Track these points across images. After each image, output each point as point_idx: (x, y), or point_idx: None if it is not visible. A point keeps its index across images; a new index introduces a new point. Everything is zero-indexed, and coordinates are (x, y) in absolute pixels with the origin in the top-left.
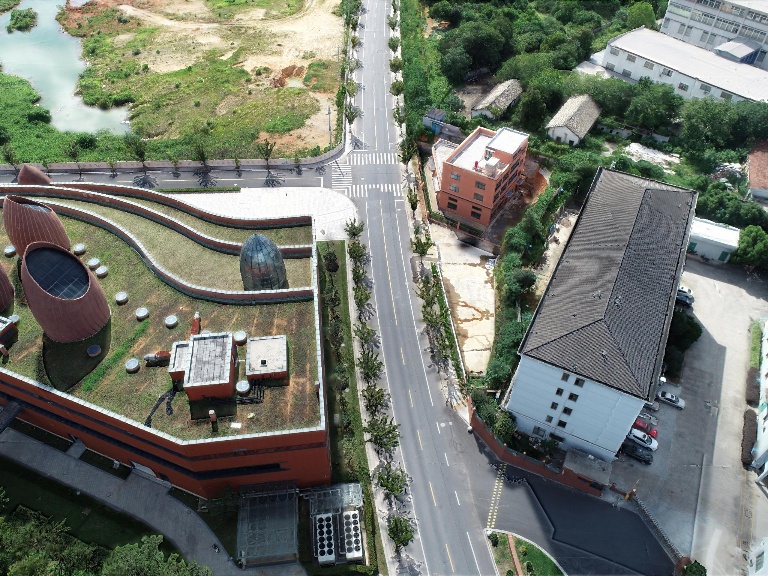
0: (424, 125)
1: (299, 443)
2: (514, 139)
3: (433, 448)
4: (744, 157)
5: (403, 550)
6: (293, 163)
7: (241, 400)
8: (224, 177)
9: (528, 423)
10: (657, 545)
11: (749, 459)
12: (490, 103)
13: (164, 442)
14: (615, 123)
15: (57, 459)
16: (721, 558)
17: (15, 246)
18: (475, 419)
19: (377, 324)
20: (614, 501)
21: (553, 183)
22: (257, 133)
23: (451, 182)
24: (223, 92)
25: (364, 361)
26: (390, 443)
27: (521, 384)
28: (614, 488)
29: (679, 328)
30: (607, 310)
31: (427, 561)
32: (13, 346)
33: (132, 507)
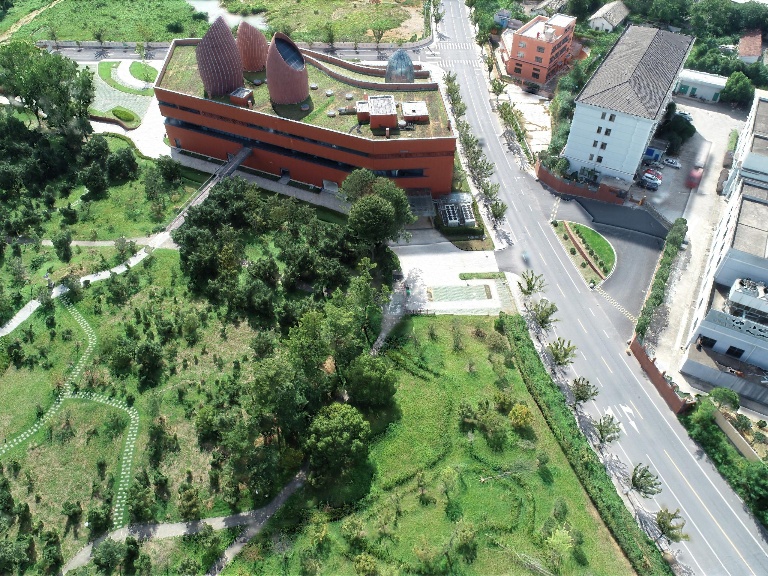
0: (494, 22)
1: (439, 150)
2: (565, 20)
3: (513, 187)
4: (737, 41)
5: (498, 227)
6: (396, 47)
7: (402, 129)
8: (346, 54)
9: (577, 165)
10: (658, 223)
11: (721, 188)
12: (545, 5)
13: (360, 145)
14: (640, 19)
15: (273, 184)
16: (698, 229)
17: (242, 57)
18: (541, 169)
19: (469, 131)
20: (632, 206)
21: (593, 54)
22: (366, 30)
23: (519, 50)
24: (334, 6)
25: (466, 139)
26: (488, 174)
27: (574, 130)
28: (632, 199)
29: (680, 125)
30: (631, 78)
31: (513, 232)
32: (253, 105)
33: (326, 205)
